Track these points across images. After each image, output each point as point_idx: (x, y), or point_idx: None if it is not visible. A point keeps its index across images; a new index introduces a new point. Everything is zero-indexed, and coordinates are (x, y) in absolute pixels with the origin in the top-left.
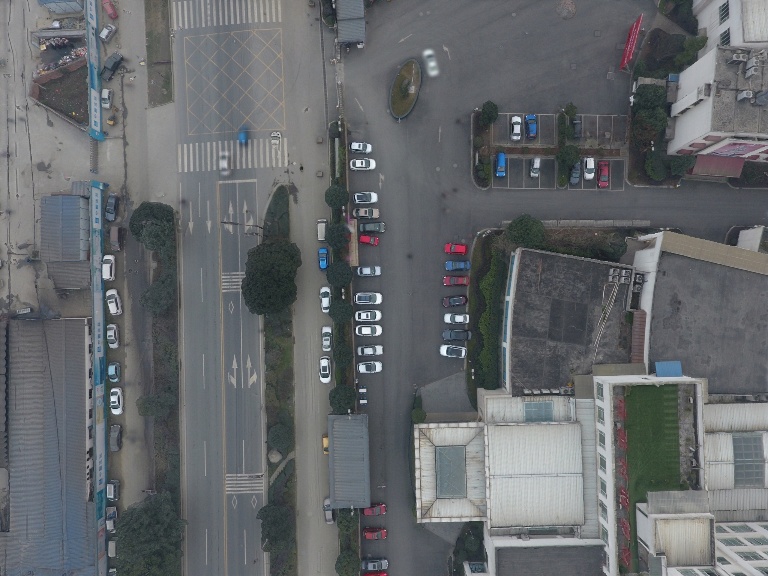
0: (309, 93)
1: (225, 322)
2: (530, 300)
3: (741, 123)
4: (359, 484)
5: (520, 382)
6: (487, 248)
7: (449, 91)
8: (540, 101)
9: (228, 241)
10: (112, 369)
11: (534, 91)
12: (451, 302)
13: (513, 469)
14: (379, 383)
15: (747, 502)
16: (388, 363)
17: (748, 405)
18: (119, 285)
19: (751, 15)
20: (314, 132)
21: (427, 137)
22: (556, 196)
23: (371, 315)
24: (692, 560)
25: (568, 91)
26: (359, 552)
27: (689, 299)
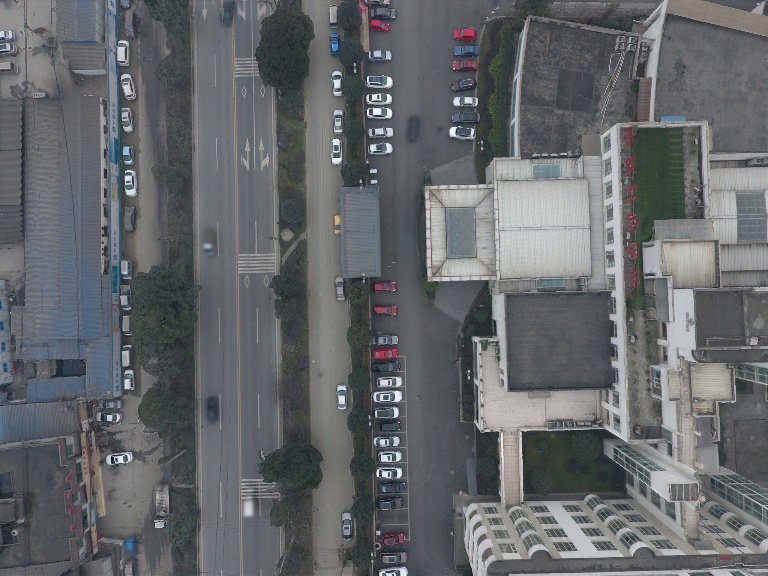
0: None
1: (238, 106)
2: (538, 70)
3: None
4: (370, 255)
5: None
6: (496, 34)
7: None
8: None
9: (241, 27)
10: (126, 150)
11: None
12: (460, 85)
13: (522, 222)
14: (389, 166)
15: (749, 262)
16: (398, 146)
17: (751, 169)
18: (133, 72)
19: None
20: None
21: None
22: None
23: (382, 97)
24: (697, 282)
25: None
26: None
27: (693, 63)
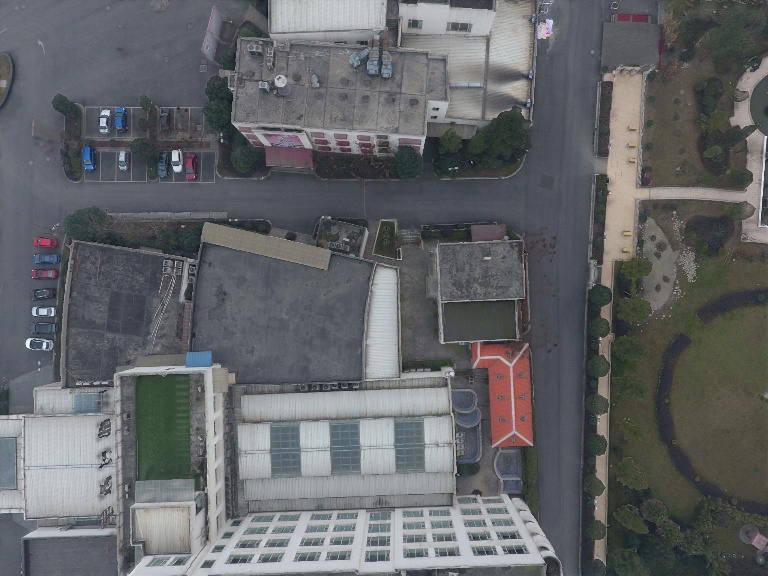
0: None
1: None
2: (89, 292)
3: (265, 114)
4: None
5: None
6: None
7: (43, 85)
8: (133, 94)
9: None
10: None
11: (127, 84)
12: (36, 295)
13: (49, 460)
14: None
15: (296, 491)
16: None
17: (298, 395)
18: None
19: (280, 6)
20: None
21: (21, 131)
22: (147, 189)
23: None
24: (172, 548)
25: (160, 84)
26: None
27: (234, 290)
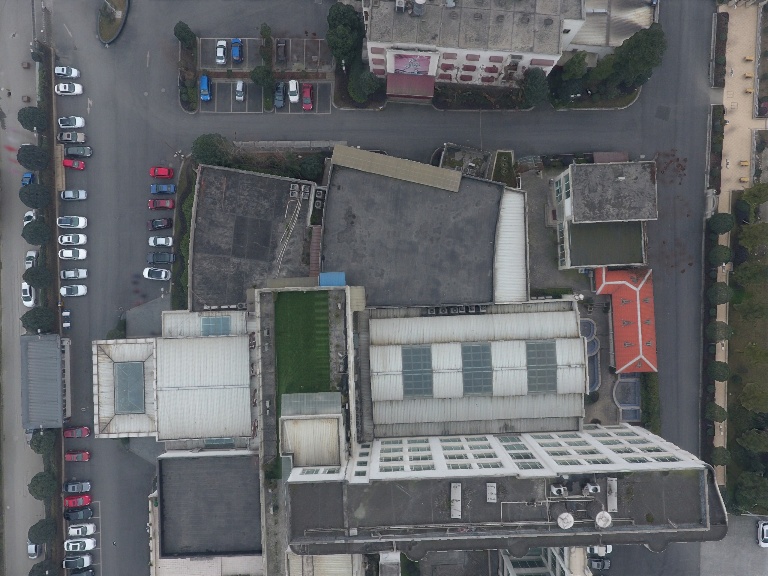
0: (17, 19)
1: None
2: (214, 217)
3: (399, 34)
4: (53, 405)
5: (198, 297)
6: (191, 171)
7: (158, 16)
8: (248, 25)
9: None
10: None
11: (242, 16)
12: (154, 225)
13: (181, 381)
14: (85, 307)
15: (425, 415)
16: (94, 287)
17: (426, 318)
18: None
19: None
20: (22, 58)
21: (136, 62)
22: (263, 120)
23: (73, 238)
24: (321, 460)
25: (276, 15)
26: (63, 475)
27: (363, 213)
